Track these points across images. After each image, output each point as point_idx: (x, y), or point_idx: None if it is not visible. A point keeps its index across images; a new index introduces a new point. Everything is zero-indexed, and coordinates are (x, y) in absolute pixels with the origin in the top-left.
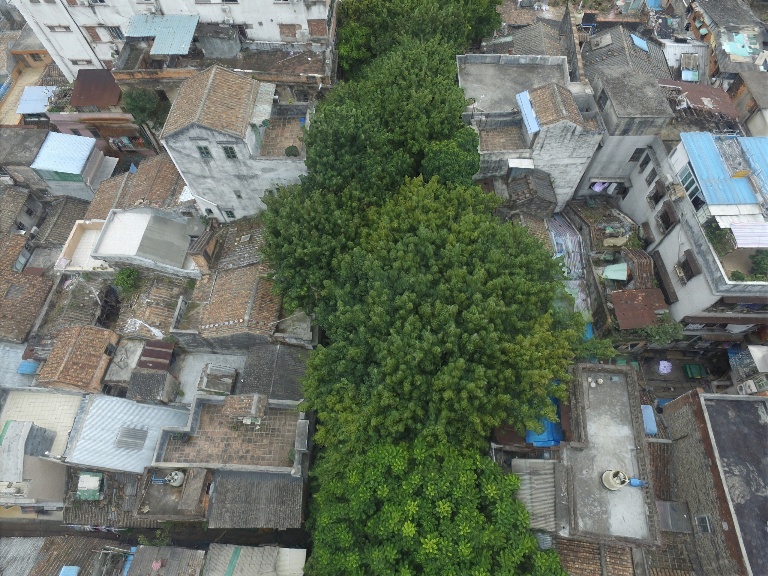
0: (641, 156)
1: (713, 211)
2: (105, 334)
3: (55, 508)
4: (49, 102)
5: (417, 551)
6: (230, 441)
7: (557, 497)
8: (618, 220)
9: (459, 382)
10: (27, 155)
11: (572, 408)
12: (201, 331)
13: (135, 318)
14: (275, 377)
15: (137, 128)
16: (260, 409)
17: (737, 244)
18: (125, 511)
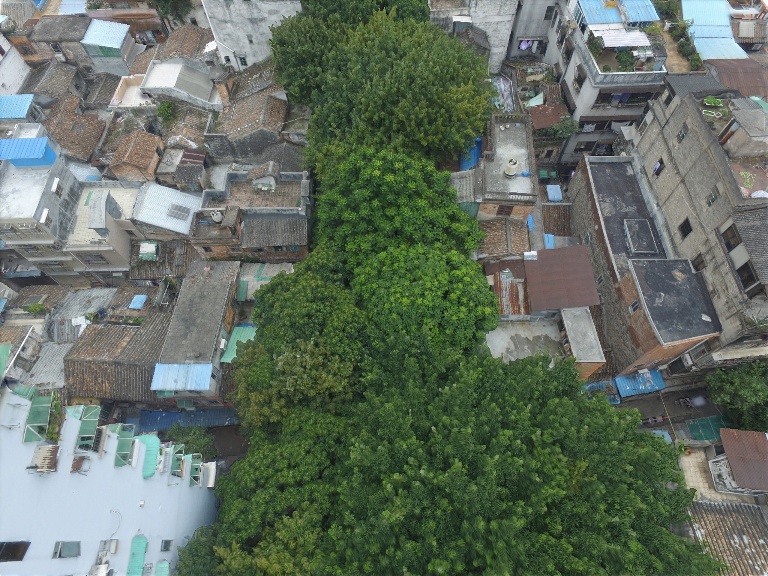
0: (552, 14)
1: (591, 28)
2: (156, 139)
3: (121, 274)
4: (87, 1)
5: (382, 186)
6: (253, 200)
7: (476, 185)
8: (538, 65)
9: (409, 112)
10: (77, 34)
11: (488, 142)
12: (227, 136)
13: (175, 135)
14: (284, 160)
15: (160, 23)
16: (275, 171)
17: (605, 45)
18: (176, 265)
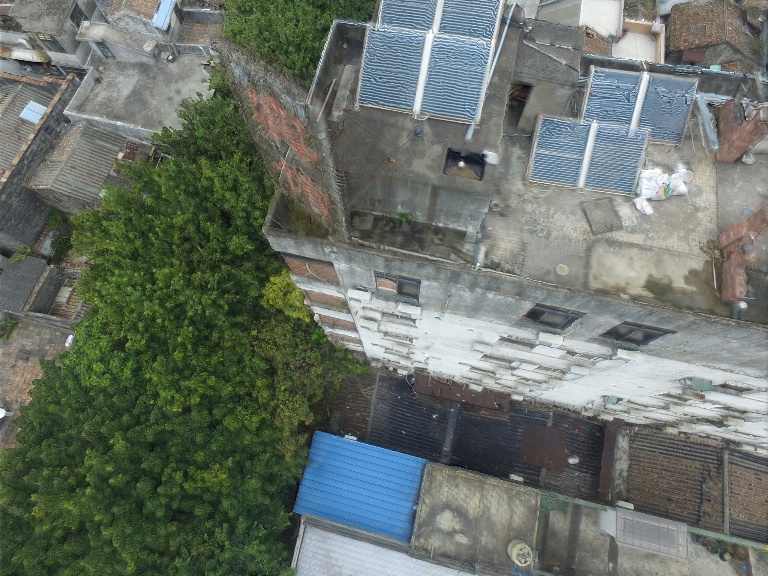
0: None
1: None
2: None
3: None
4: None
5: None
6: None
7: None
8: None
9: None
10: None
11: None
12: None
13: None
14: None
15: None
16: None
17: None
18: None
